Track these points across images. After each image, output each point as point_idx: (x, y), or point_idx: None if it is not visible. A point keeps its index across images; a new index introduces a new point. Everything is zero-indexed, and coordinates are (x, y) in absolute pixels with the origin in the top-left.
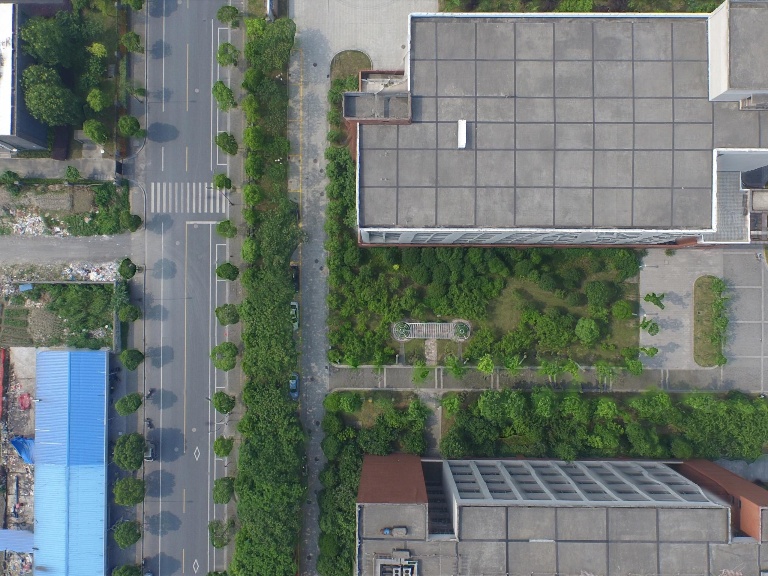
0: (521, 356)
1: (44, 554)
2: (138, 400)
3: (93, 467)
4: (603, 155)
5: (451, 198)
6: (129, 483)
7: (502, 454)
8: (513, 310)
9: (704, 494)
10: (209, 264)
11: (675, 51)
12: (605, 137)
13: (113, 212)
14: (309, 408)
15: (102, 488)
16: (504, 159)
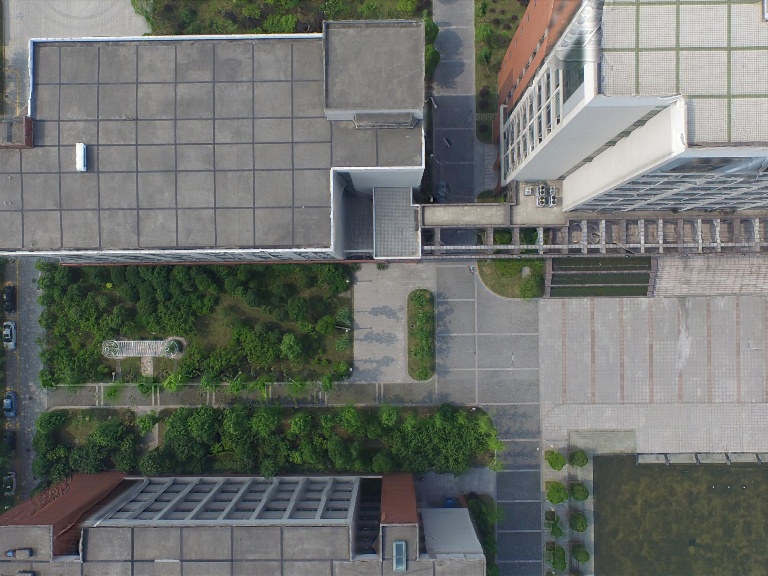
0: (235, 372)
1: None
2: None
3: None
4: (224, 176)
5: (75, 221)
6: None
7: (213, 470)
8: None
9: (354, 510)
10: None
11: (295, 71)
12: (225, 158)
13: None
14: (27, 427)
15: None
16: (126, 181)
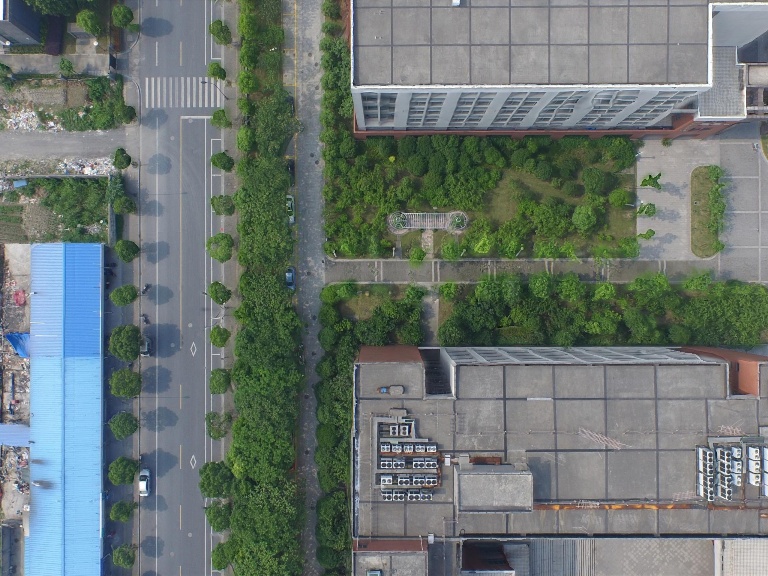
0: (518, 248)
1: (40, 447)
2: (134, 291)
3: (89, 359)
4: (598, 12)
5: (446, 56)
6: (125, 374)
7: None
8: (510, 202)
9: None
10: (204, 159)
11: None
12: None
13: (107, 106)
14: (306, 302)
15: (98, 380)
16: (499, 16)
